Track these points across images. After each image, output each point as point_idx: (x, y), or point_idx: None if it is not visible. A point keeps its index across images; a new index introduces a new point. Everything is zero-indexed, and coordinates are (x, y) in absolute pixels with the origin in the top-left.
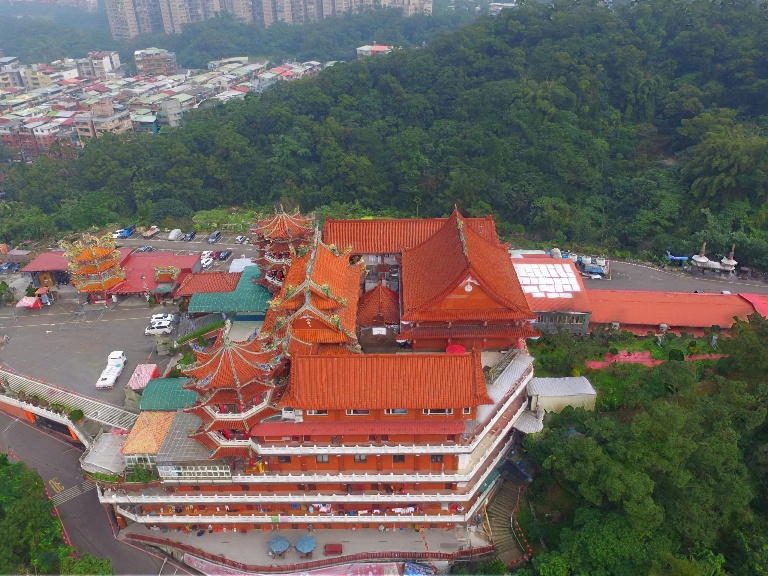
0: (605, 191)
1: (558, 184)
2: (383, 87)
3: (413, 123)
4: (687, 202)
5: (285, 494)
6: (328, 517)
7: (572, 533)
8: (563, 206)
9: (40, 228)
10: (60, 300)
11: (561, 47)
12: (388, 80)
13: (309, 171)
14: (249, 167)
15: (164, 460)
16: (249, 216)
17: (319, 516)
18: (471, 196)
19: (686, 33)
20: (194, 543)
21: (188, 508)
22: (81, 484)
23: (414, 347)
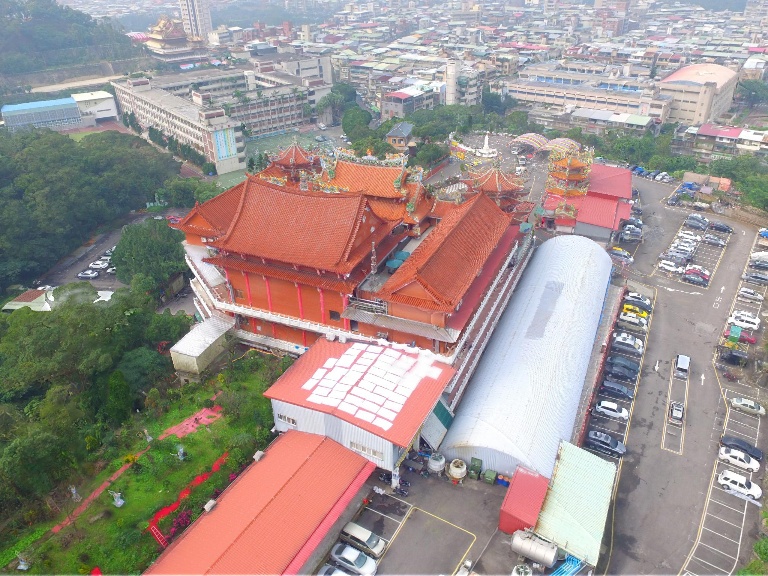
0: None
1: None
2: None
3: None
4: None
5: None
6: None
7: None
8: None
9: None
10: None
11: None
12: None
13: None
14: None
15: None
16: None
17: None
18: None
19: None
20: None
21: None
22: None
23: None
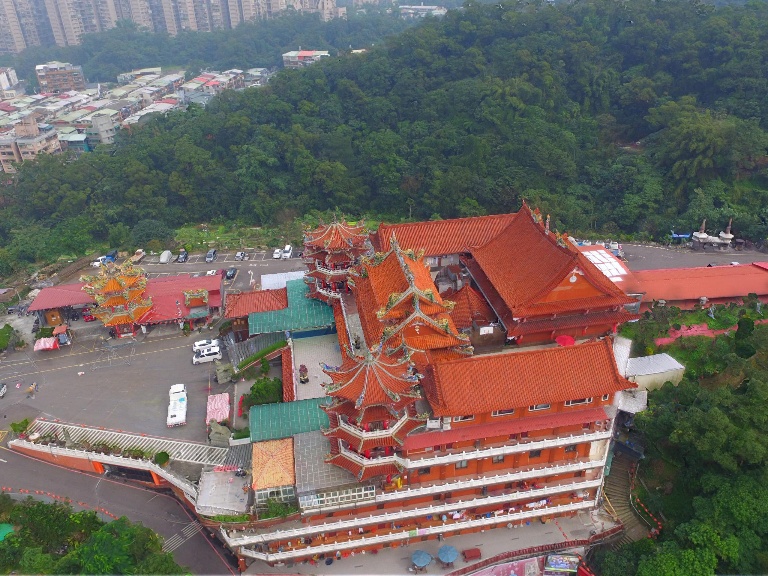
0: (581, 180)
1: (539, 176)
2: (341, 92)
3: (378, 126)
4: (667, 184)
5: (425, 506)
6: (465, 523)
7: (706, 500)
8: (549, 197)
9: (9, 263)
10: (77, 338)
11: (518, 45)
12: (347, 84)
13: (281, 181)
14: (212, 181)
15: (307, 490)
16: (222, 232)
17: (457, 523)
18: (458, 194)
19: (631, 28)
20: (327, 573)
21: (320, 537)
22: (181, 531)
23: (519, 343)
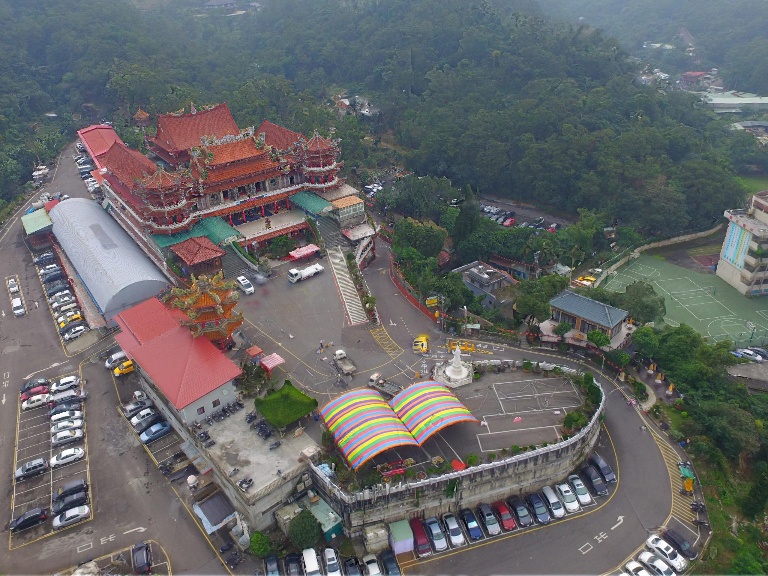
0: None
1: None
2: None
3: None
4: None
5: None
6: None
7: None
8: None
9: None
10: None
11: None
12: None
13: None
14: None
15: None
16: None
17: None
18: None
19: None
20: None
21: None
22: None
23: None
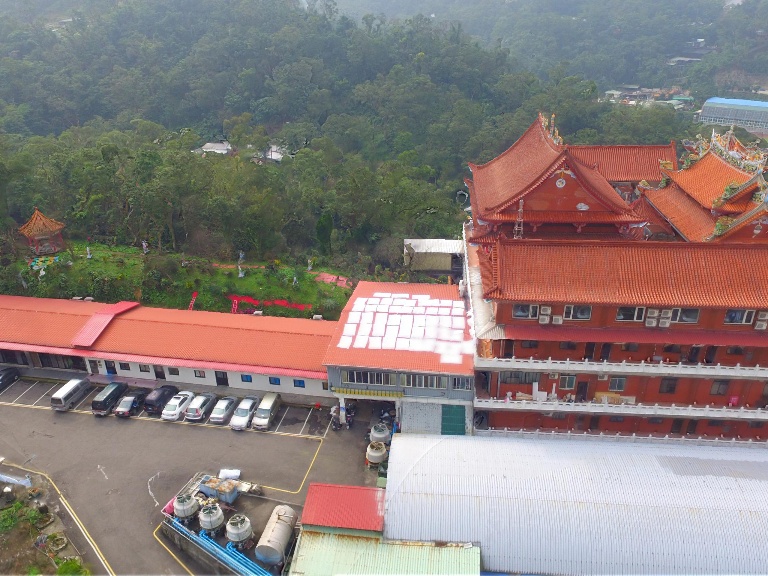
0: None
1: None
2: None
3: None
4: None
5: None
6: None
7: None
8: None
9: None
10: None
11: None
12: None
13: None
14: None
15: None
16: None
17: None
18: None
19: None
20: None
21: None
22: None
23: None
